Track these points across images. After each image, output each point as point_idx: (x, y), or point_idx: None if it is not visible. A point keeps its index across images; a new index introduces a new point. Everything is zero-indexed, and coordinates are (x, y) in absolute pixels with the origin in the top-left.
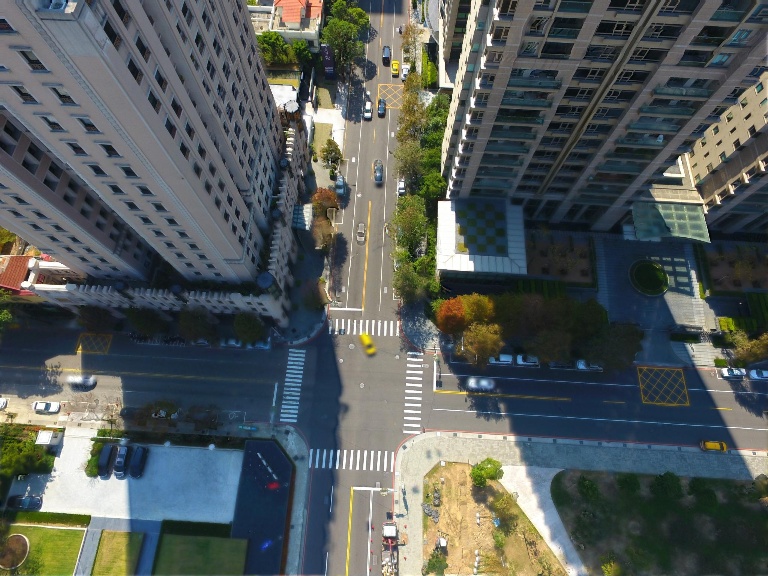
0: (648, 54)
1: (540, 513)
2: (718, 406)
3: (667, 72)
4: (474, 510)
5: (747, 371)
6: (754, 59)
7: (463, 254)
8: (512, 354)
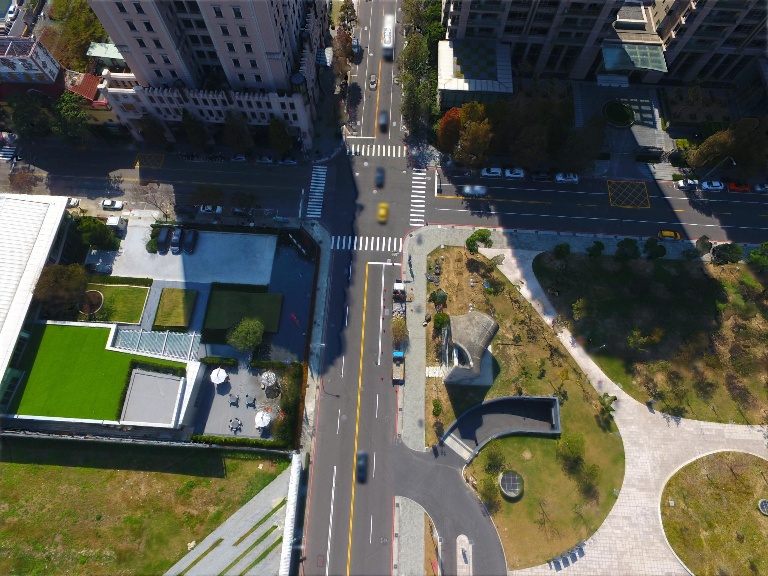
0: None
1: (523, 281)
2: (674, 209)
3: None
4: (468, 277)
5: (700, 183)
6: None
7: (460, 78)
8: (501, 170)
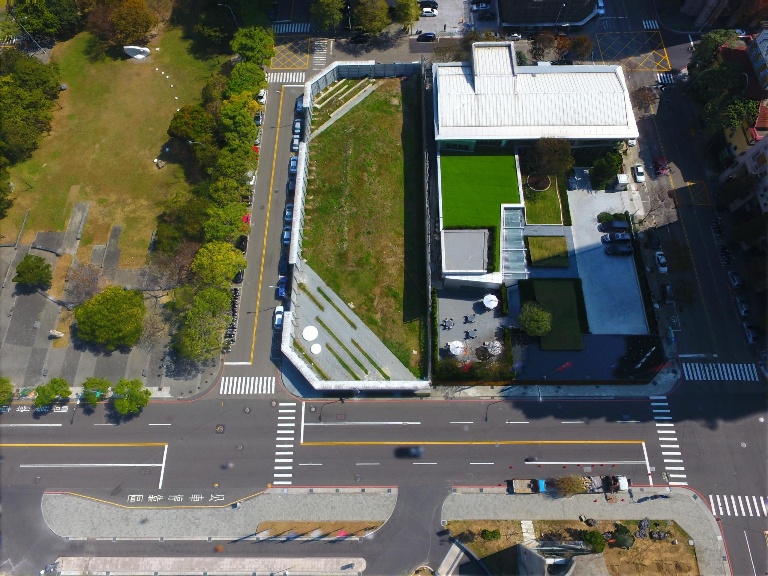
0: None
1: None
2: None
3: None
4: None
5: None
6: None
7: None
8: None
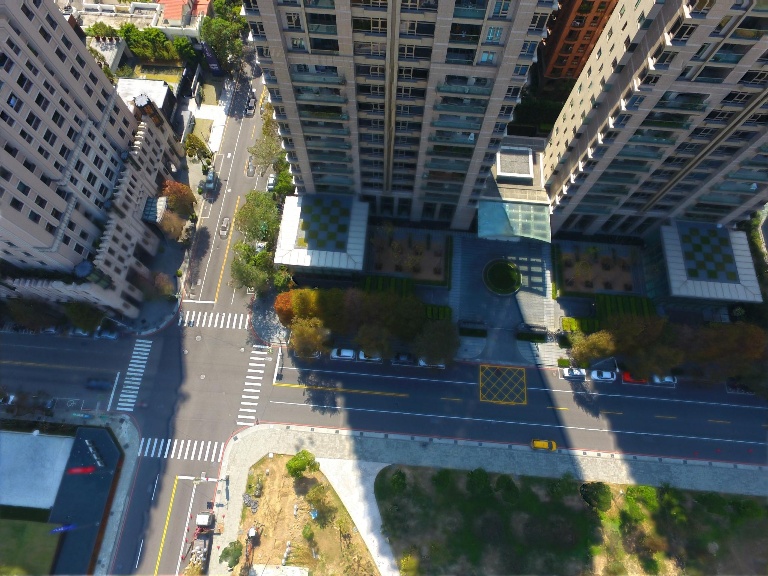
0: (416, 52)
1: (360, 507)
2: (555, 406)
3: (441, 70)
4: (293, 502)
5: (589, 372)
6: (511, 58)
7: (302, 249)
8: (356, 349)
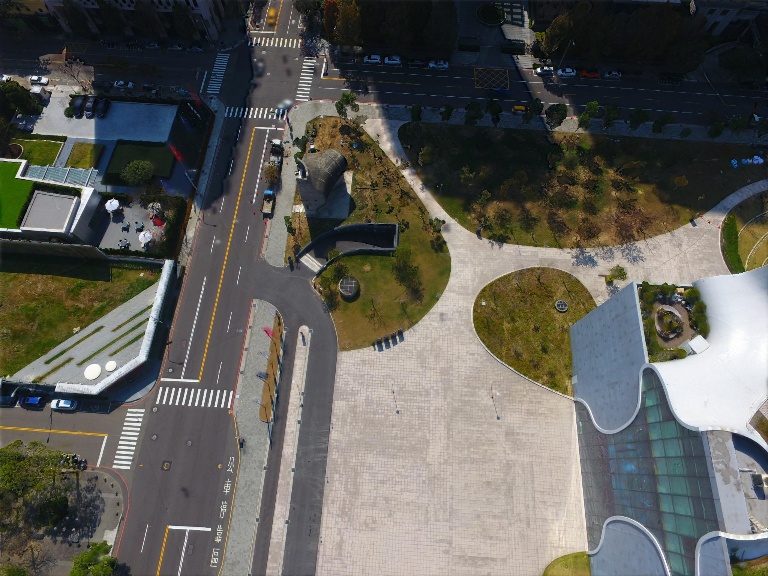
0: None
1: (388, 144)
2: (530, 90)
3: None
4: (340, 139)
5: (556, 71)
6: None
7: None
8: (382, 58)
